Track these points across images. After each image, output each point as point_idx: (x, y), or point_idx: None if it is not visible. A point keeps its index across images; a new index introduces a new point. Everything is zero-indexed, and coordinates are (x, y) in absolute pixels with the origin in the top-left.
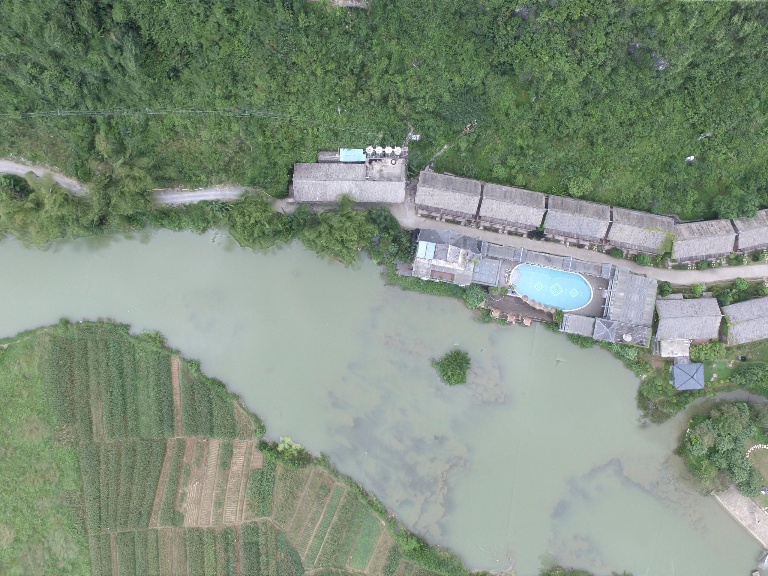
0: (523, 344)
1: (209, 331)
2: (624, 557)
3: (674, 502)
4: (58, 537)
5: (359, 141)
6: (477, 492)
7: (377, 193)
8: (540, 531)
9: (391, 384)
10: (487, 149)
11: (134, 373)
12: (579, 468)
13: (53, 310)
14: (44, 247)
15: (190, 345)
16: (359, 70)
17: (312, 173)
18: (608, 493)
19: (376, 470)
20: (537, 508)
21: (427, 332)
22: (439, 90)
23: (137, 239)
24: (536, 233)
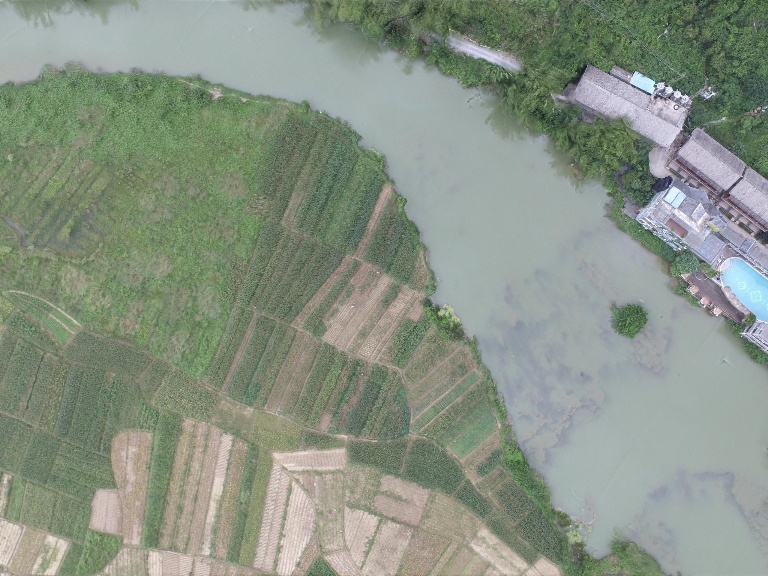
0: (701, 330)
1: (428, 178)
2: (694, 564)
3: (764, 538)
4: (208, 292)
5: (658, 72)
6: (594, 441)
7: (649, 127)
8: (632, 503)
9: (566, 306)
10: (762, 139)
11: (346, 181)
12: (695, 465)
13: (300, 90)
14: (323, 29)
15: (406, 182)
16: (705, 4)
17: (601, 80)
18: (710, 500)
19: (515, 376)
20: (641, 481)
21: (620, 277)
22: (761, 60)
23: (400, 66)
24: (767, 236)
